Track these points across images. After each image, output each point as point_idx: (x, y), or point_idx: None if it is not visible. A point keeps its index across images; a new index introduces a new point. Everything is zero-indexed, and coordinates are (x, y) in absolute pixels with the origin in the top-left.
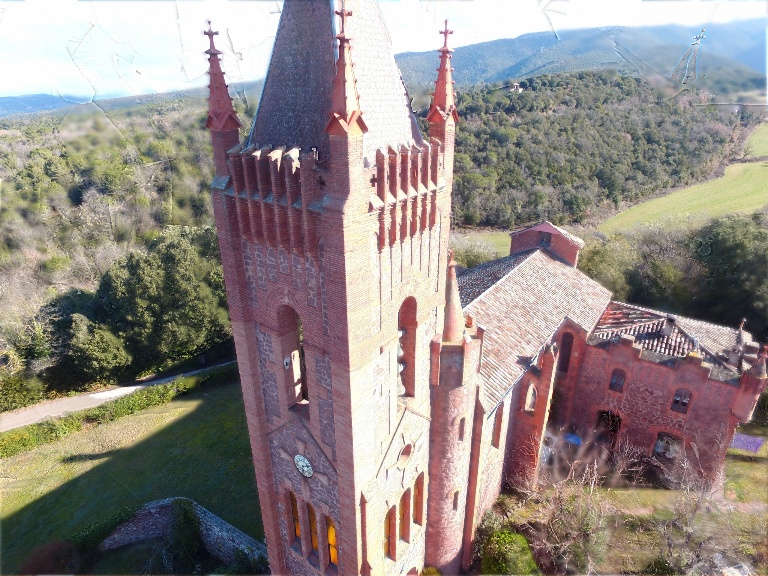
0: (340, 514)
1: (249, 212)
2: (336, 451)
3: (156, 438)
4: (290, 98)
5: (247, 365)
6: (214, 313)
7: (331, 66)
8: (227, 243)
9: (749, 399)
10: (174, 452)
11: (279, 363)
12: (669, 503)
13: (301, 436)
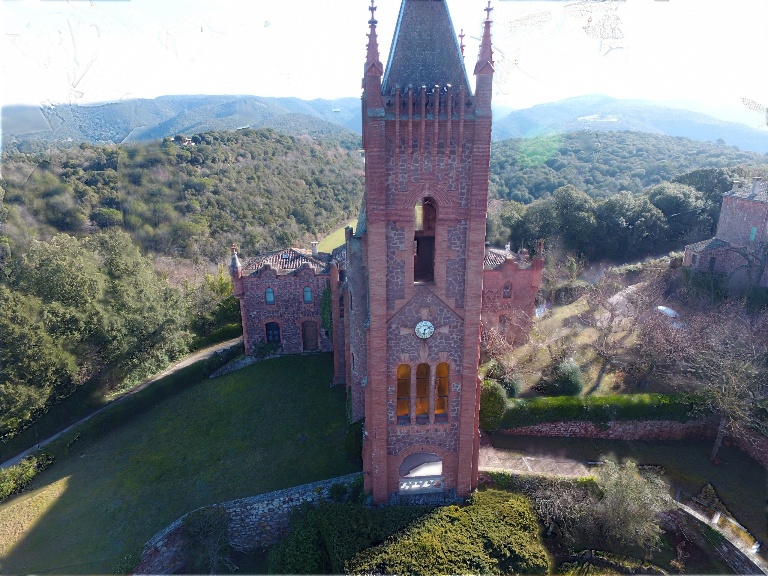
0: (465, 345)
1: (409, 129)
2: (467, 291)
3: (62, 512)
4: (420, 58)
5: (382, 259)
6: (63, 358)
7: (452, 40)
8: (379, 158)
9: (539, 274)
10: (111, 507)
11: (410, 248)
12: (520, 353)
13: (425, 304)
